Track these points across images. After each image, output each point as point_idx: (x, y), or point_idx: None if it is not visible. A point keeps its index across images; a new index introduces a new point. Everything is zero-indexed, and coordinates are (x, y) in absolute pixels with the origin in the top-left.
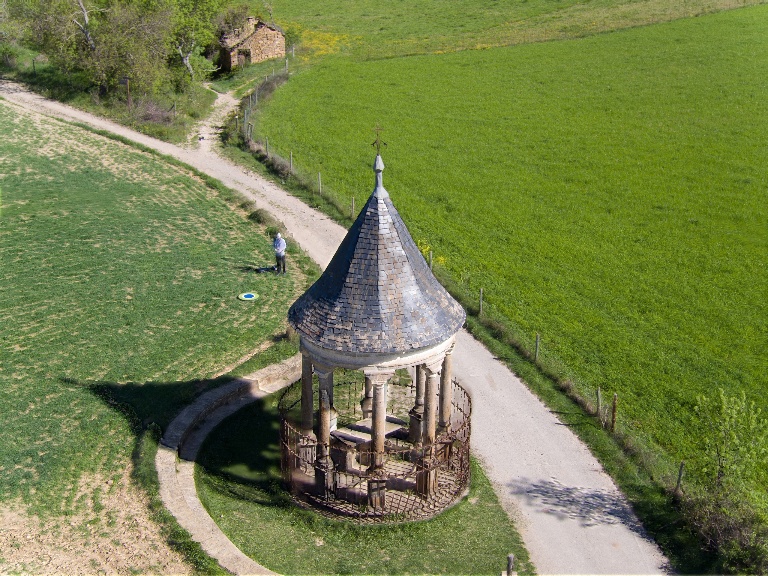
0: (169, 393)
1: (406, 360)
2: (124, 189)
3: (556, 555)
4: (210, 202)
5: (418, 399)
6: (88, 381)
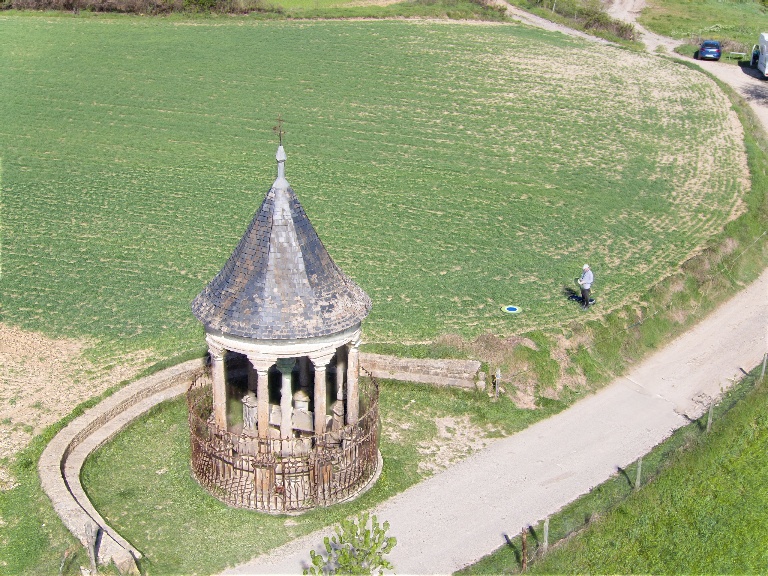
0: None
1: (229, 342)
2: (647, 203)
3: None
4: (688, 237)
5: (347, 416)
6: None
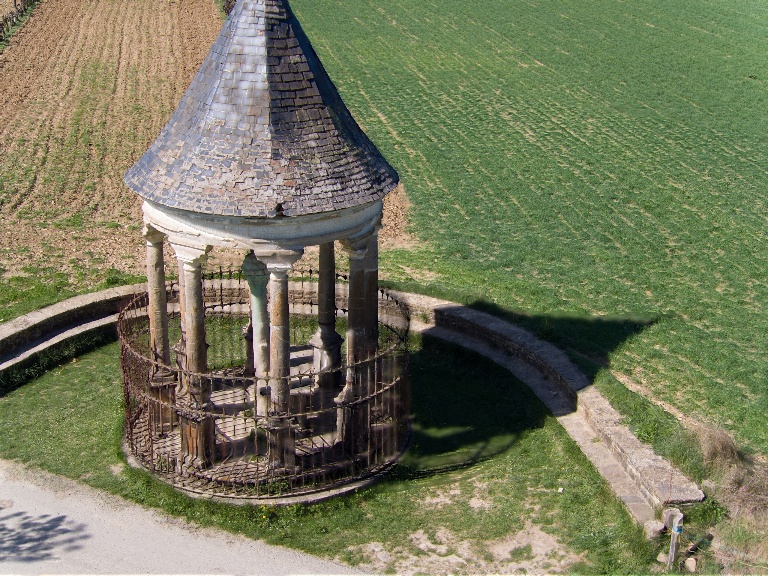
0: (583, 334)
1: None
2: None
3: None
4: None
5: None
6: (669, 310)
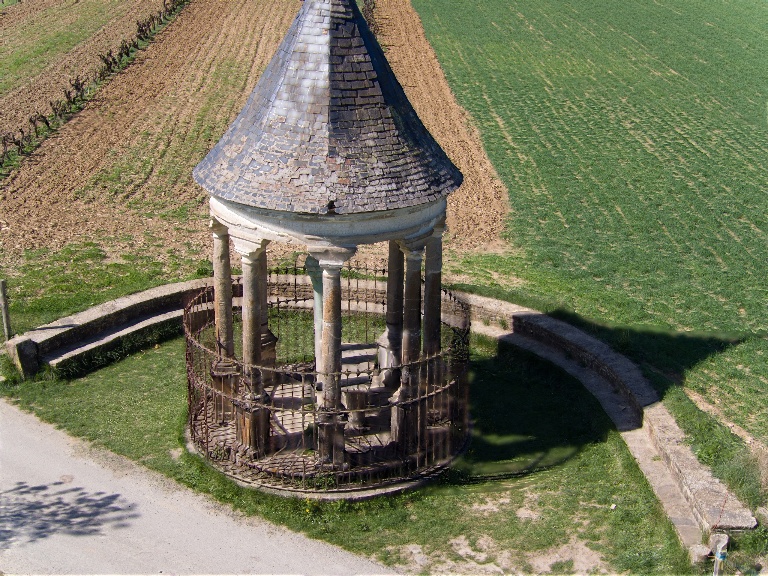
0: (662, 349)
1: None
2: None
3: (8, 431)
4: None
5: None
6: (761, 329)
